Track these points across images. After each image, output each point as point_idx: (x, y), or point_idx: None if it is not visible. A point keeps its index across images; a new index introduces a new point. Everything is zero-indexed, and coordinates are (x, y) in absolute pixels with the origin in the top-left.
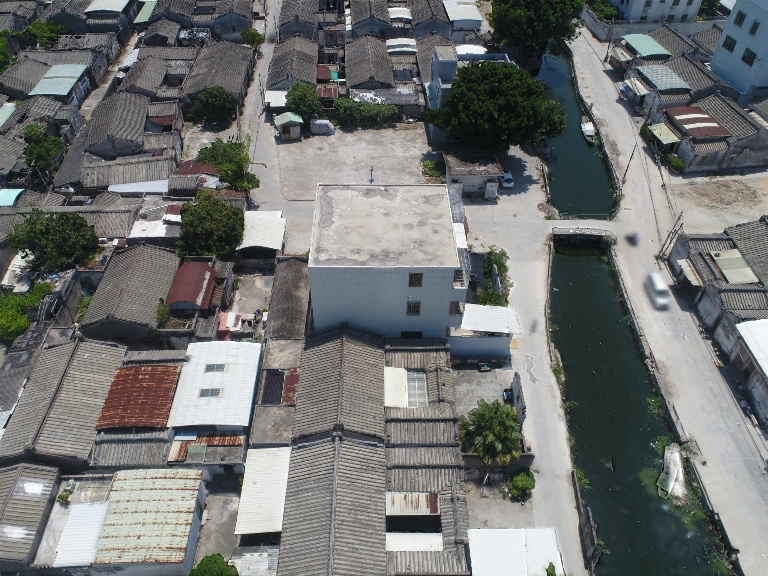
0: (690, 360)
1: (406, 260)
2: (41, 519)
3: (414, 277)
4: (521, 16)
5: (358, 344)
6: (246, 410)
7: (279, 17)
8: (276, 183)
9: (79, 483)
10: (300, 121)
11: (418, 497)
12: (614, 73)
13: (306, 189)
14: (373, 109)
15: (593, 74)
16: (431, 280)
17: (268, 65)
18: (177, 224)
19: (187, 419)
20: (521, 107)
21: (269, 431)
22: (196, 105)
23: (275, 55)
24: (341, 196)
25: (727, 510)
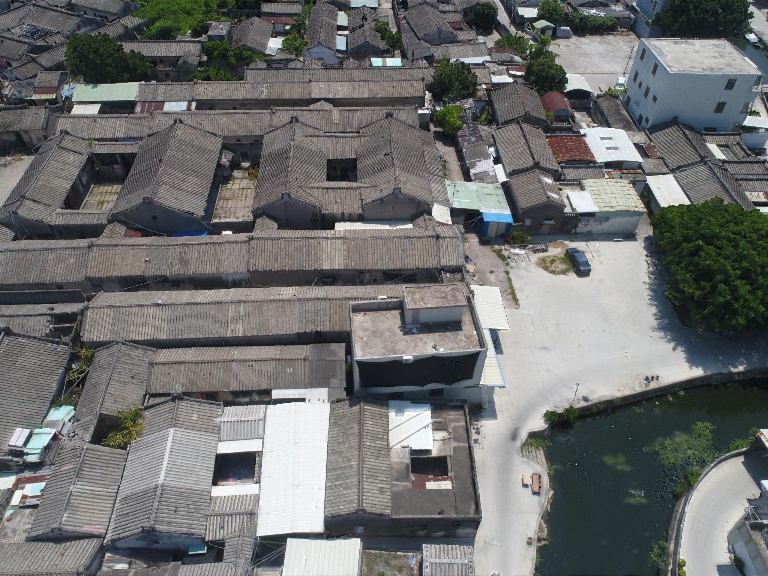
0: None
1: (726, 71)
2: None
3: (731, 82)
4: None
5: (686, 129)
6: (639, 156)
7: None
8: None
9: None
10: (553, 26)
11: (758, 194)
12: (756, 4)
13: (575, 68)
14: (600, 20)
15: None
16: (740, 84)
17: None
18: (519, 77)
19: (607, 158)
20: None
21: (653, 168)
22: (471, 16)
23: None
24: (661, 44)
25: None
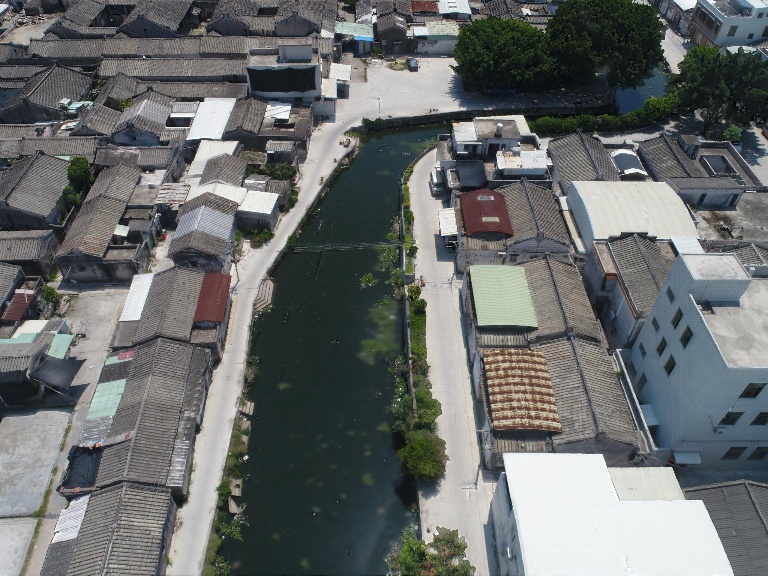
0: None
1: None
2: None
3: None
4: None
5: None
6: (469, 11)
7: None
8: None
9: (411, 26)
10: None
11: None
12: None
13: None
14: None
15: None
16: None
17: None
18: None
19: None
20: None
21: None
22: None
23: None
24: None
25: None
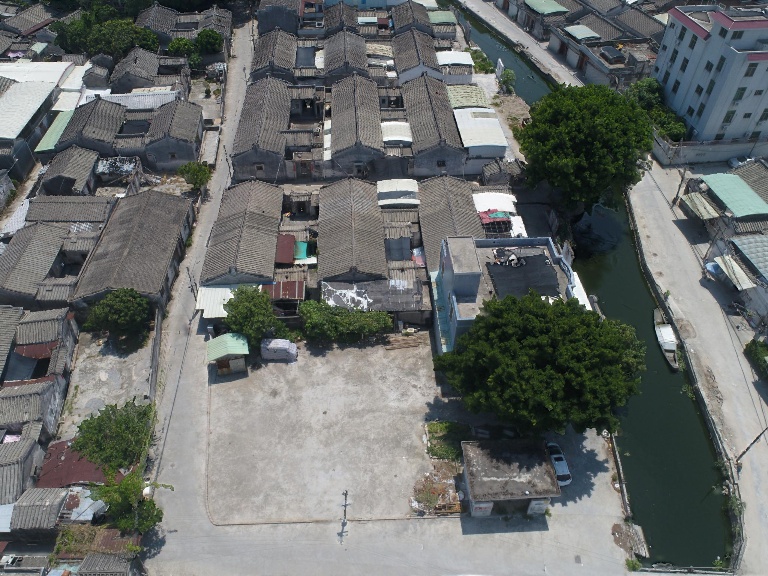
0: None
1: None
2: None
3: None
4: (567, 165)
5: None
6: None
7: (235, 136)
8: (199, 479)
9: None
10: (244, 352)
11: None
12: (689, 226)
13: (245, 493)
14: (355, 321)
15: (661, 228)
16: None
17: (215, 215)
18: None
19: None
20: (590, 391)
21: None
22: (93, 316)
23: (221, 211)
24: None
25: None
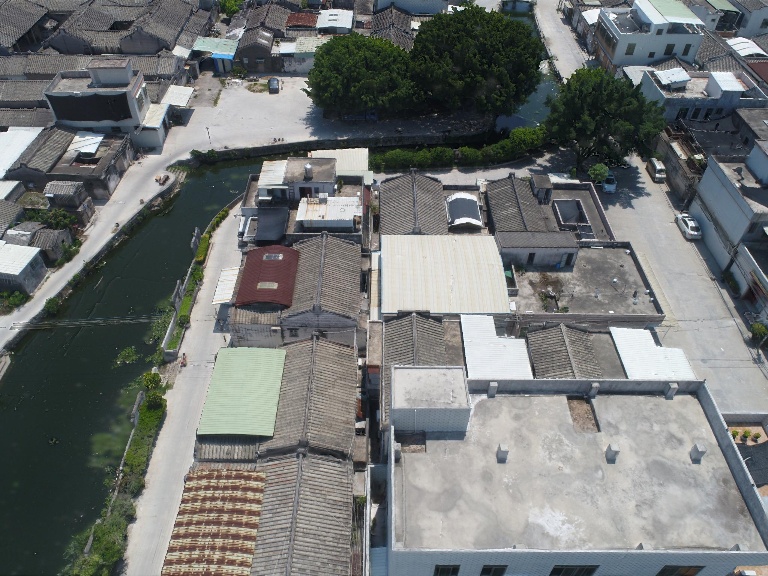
0: (562, 37)
1: None
2: (271, 43)
3: None
4: None
5: (399, 11)
6: (350, 25)
7: None
8: None
9: (281, 42)
10: None
11: None
12: None
13: None
14: None
15: None
16: None
17: None
18: None
19: (324, 25)
20: None
21: None
22: None
23: None
24: None
25: (563, 70)
